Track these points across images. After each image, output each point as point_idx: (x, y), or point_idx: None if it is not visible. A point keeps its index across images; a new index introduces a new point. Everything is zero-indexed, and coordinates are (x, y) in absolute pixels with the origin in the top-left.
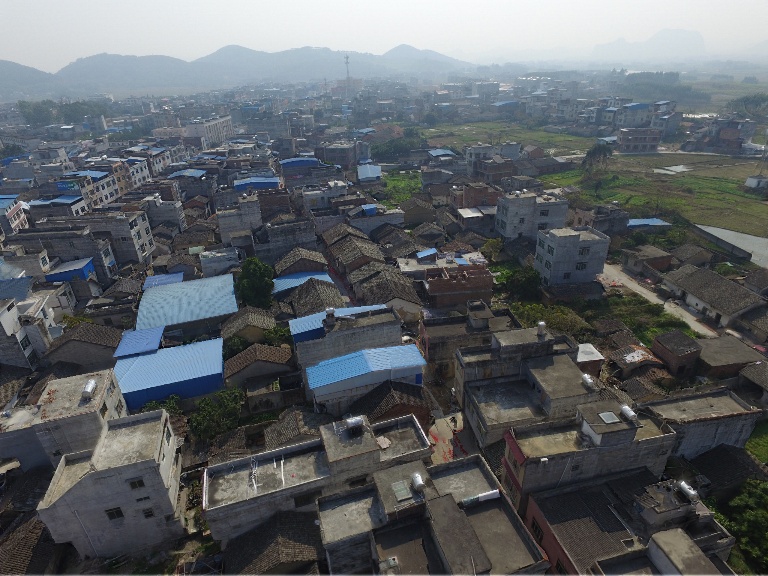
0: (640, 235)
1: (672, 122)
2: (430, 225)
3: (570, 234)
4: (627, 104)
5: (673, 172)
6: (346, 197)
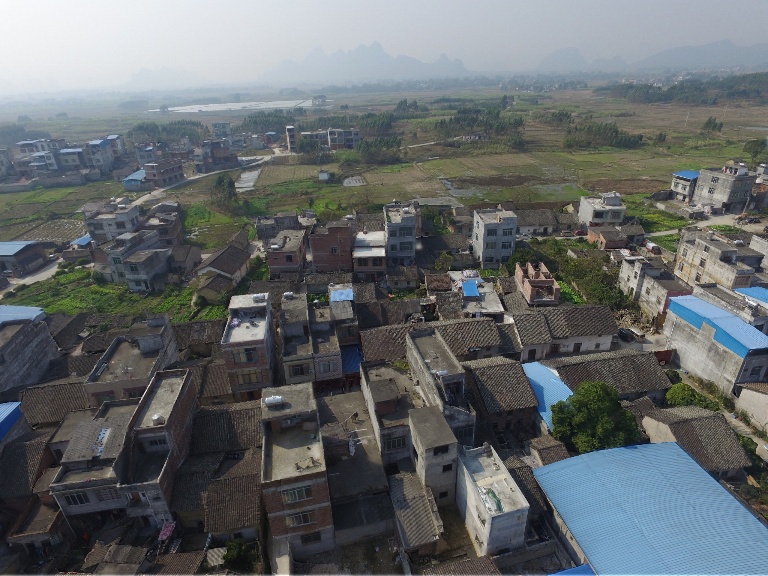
0: (433, 215)
1: (155, 152)
2: (367, 283)
3: (512, 213)
4: (91, 142)
5: (250, 188)
6: (290, 307)
